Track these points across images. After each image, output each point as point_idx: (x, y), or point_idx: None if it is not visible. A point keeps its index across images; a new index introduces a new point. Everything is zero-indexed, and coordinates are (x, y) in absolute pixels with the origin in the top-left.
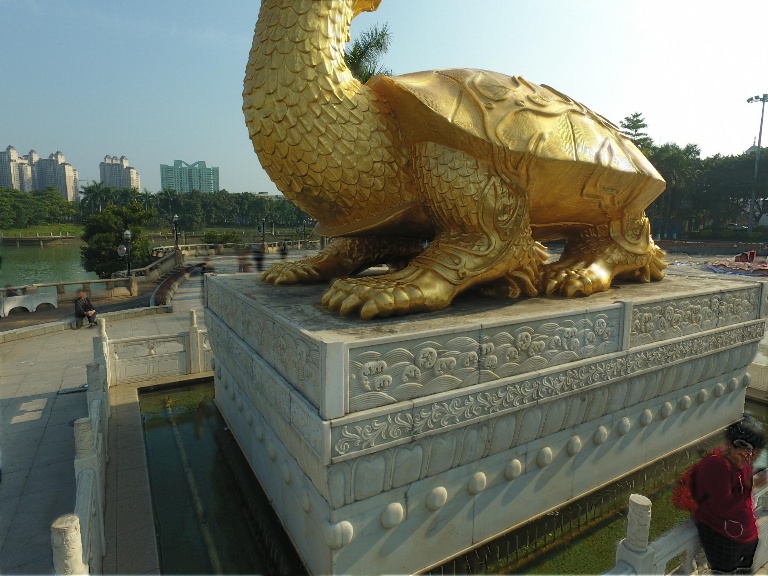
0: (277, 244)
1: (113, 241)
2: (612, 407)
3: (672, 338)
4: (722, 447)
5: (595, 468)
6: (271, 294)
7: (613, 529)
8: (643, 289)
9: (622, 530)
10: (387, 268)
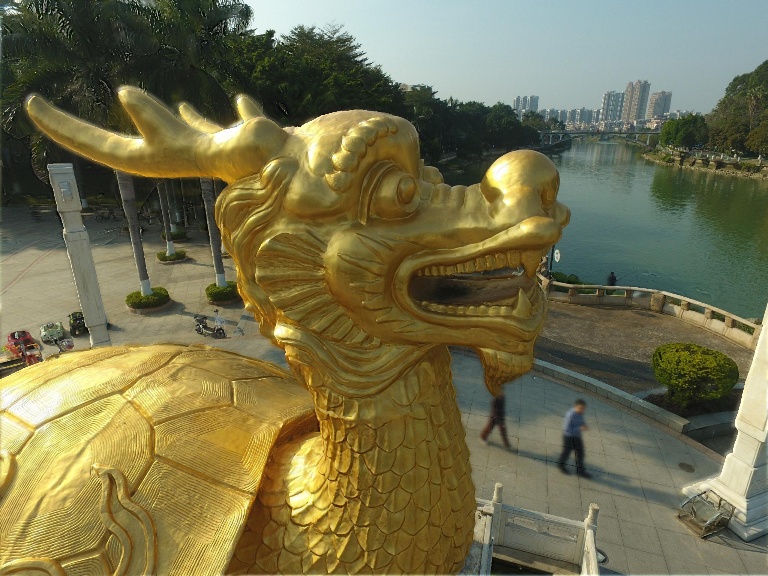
0: None
1: None
2: None
3: None
4: None
5: None
6: None
7: None
8: None
9: None
10: None
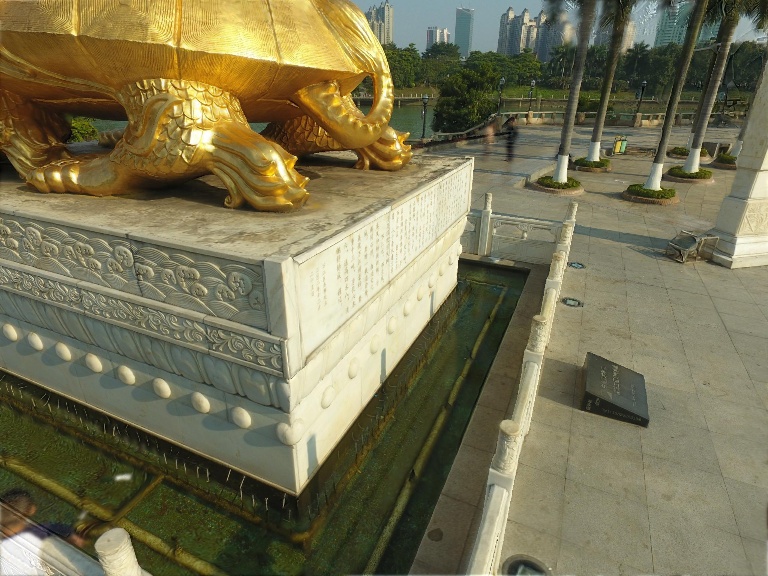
0: (662, 116)
1: (453, 105)
2: (6, 311)
3: (53, 272)
4: (174, 470)
5: (21, 360)
6: None
7: (2, 411)
8: (132, 207)
9: (4, 418)
10: None
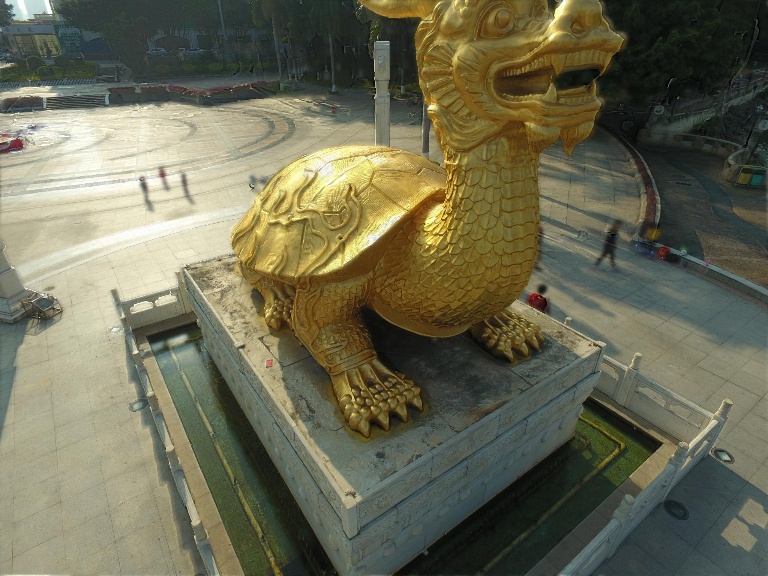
0: None
1: None
2: None
3: None
4: None
5: None
6: (476, 399)
7: None
8: None
9: None
10: (260, 347)
